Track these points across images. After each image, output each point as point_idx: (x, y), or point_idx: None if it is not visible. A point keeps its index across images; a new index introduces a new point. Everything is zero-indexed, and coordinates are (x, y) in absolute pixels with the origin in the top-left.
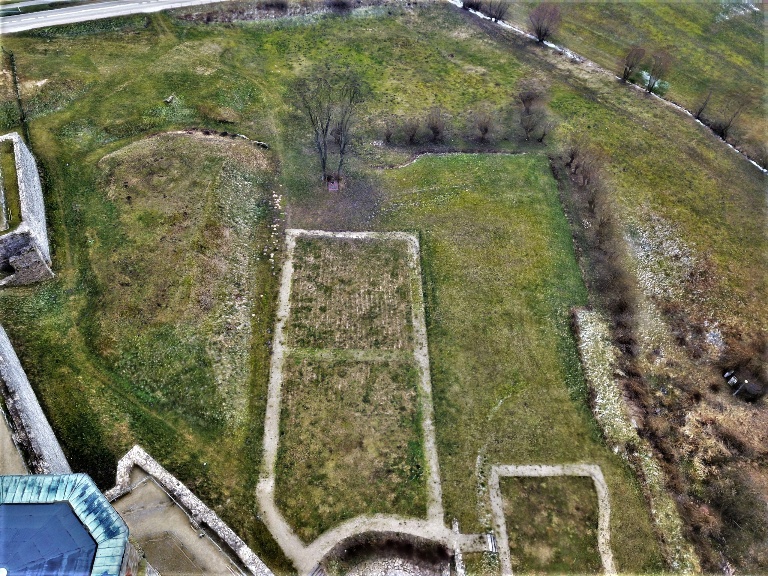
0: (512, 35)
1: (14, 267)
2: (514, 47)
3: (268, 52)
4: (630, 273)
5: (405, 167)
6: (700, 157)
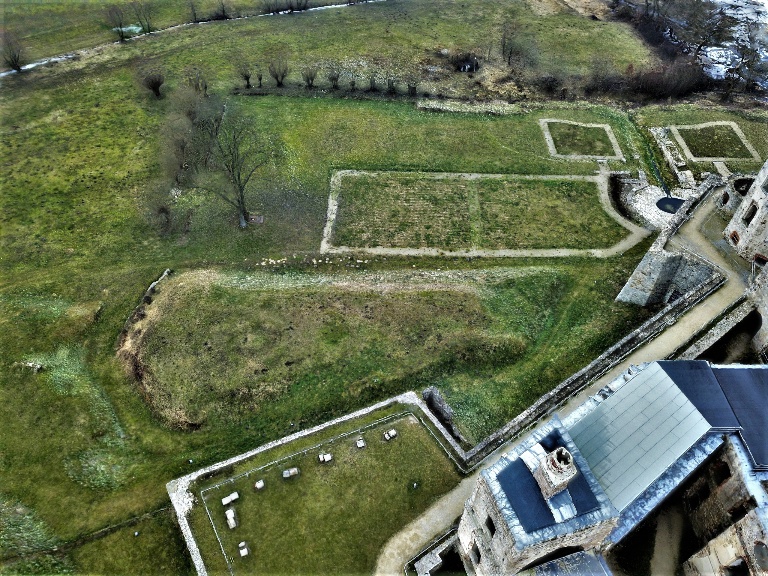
0: None
1: None
2: (20, 87)
3: None
4: None
5: None
6: (252, 32)
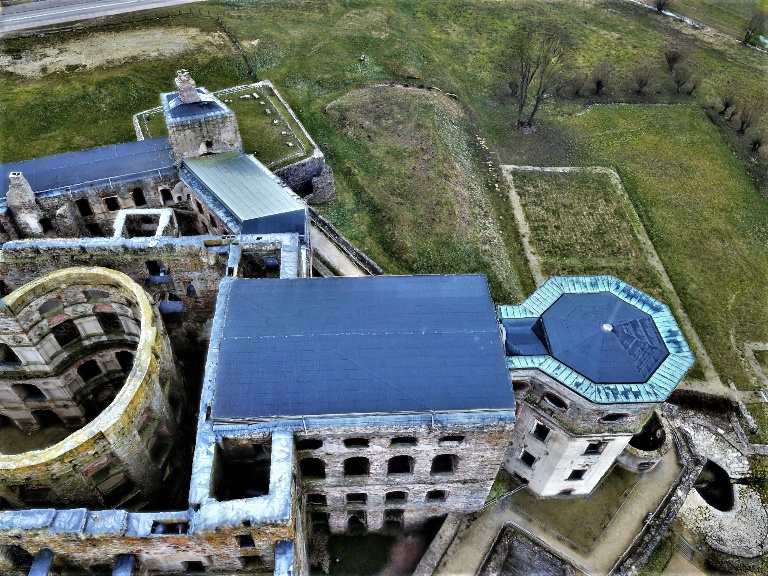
0: (632, 5)
1: (315, 186)
2: (637, 15)
3: (422, 20)
4: None
5: (582, 115)
6: None
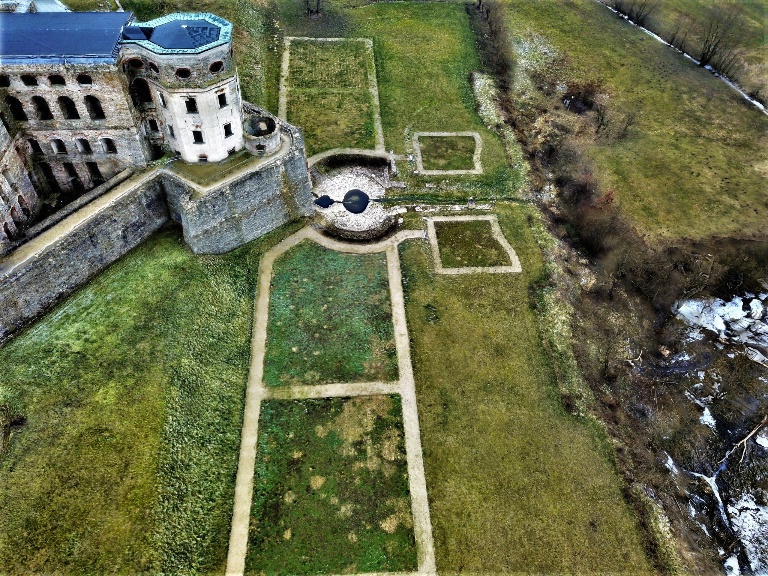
0: None
1: None
2: None
3: None
4: (513, 59)
5: (364, 7)
6: (572, 4)
